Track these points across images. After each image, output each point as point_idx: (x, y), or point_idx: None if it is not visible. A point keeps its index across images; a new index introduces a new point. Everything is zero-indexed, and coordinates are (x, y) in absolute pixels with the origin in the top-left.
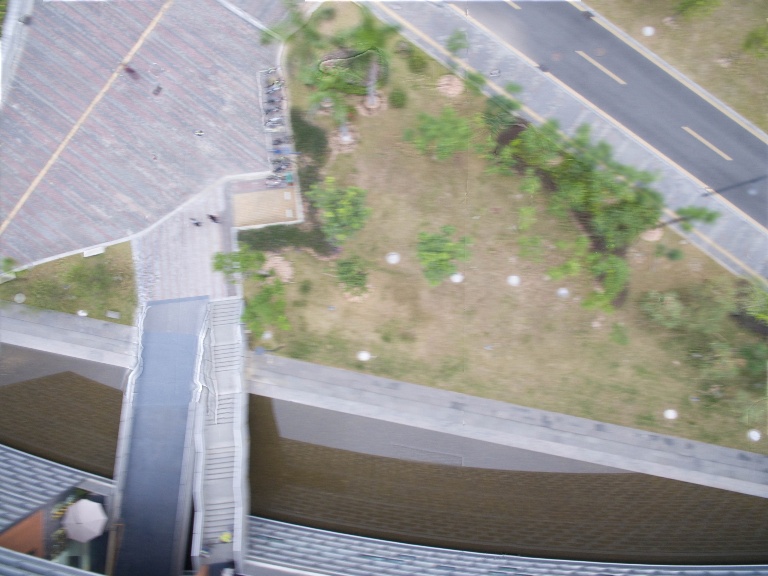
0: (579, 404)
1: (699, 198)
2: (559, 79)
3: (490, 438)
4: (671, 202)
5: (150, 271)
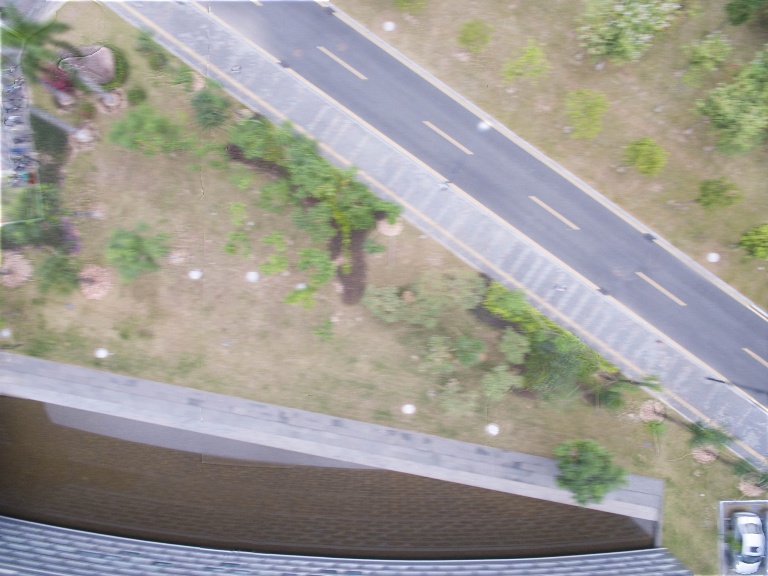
0: (316, 399)
1: (439, 192)
2: (300, 75)
3: (229, 434)
4: (411, 197)
5: None
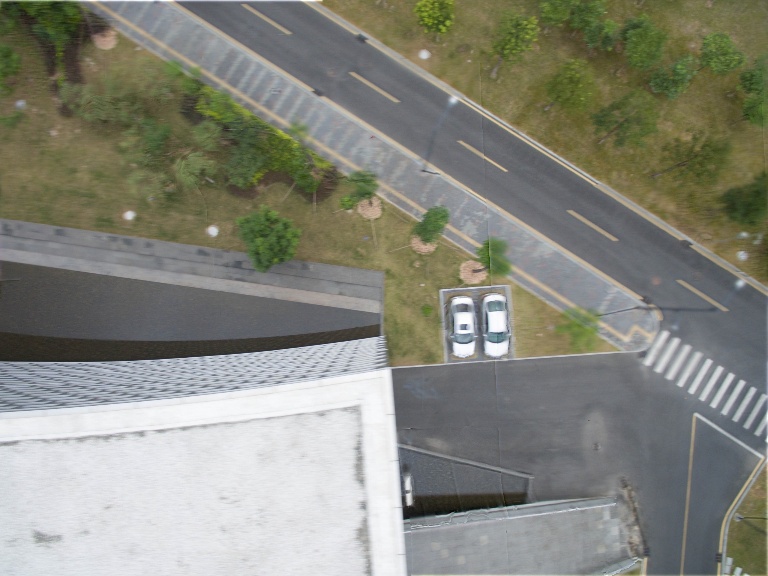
0: (39, 211)
1: (152, 5)
2: None
3: None
4: (126, 11)
5: None
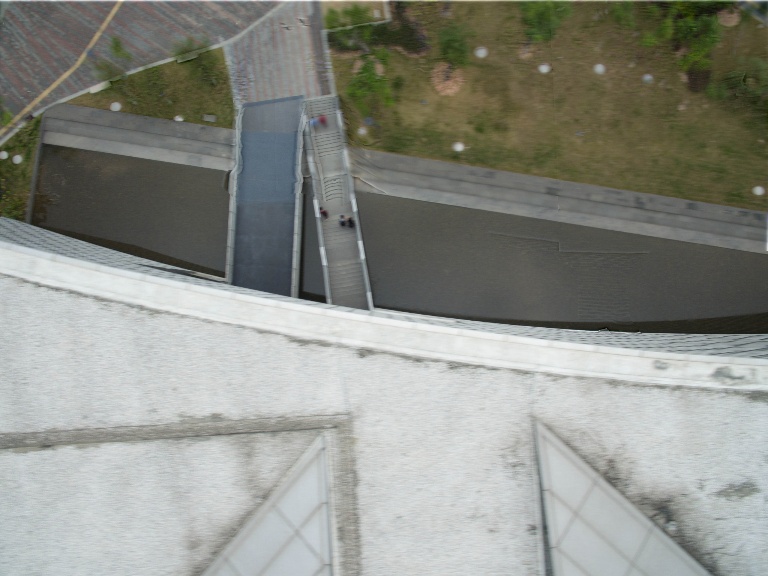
0: (670, 184)
1: None
2: None
3: (585, 222)
4: None
5: (243, 75)
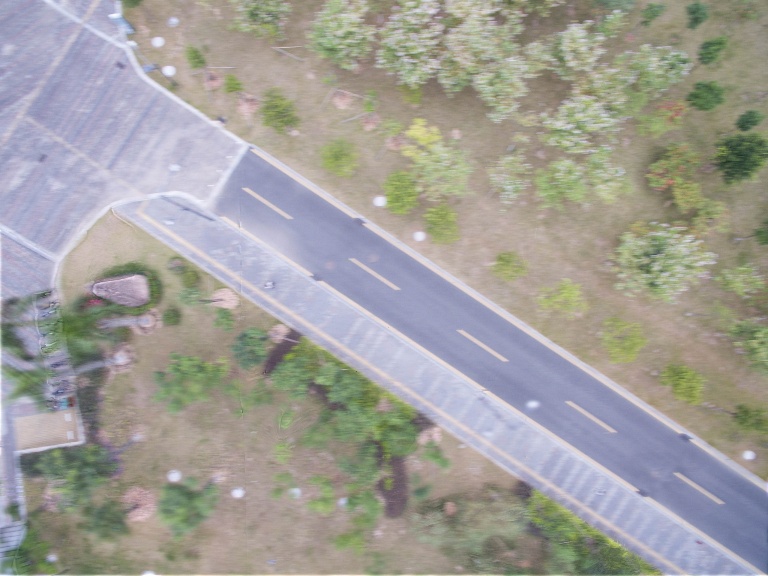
0: None
1: (476, 401)
2: (334, 287)
3: None
4: (449, 406)
5: None
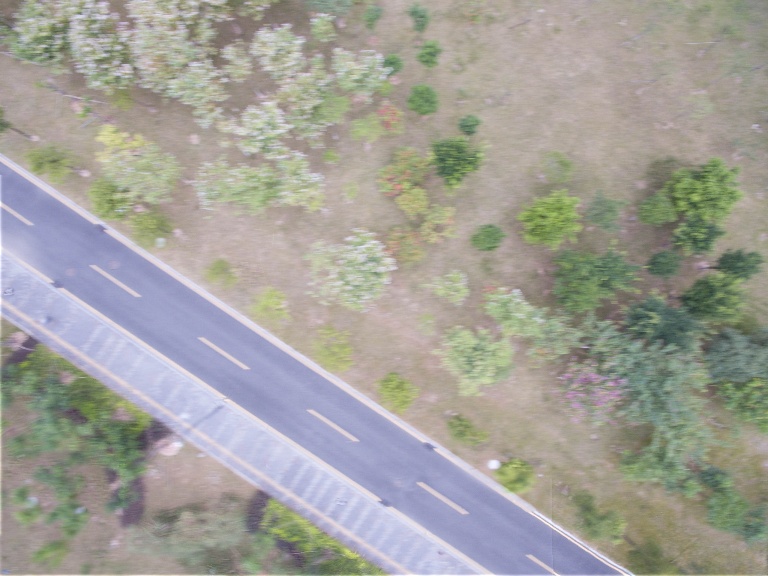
0: None
1: (216, 410)
2: (74, 294)
3: None
4: (188, 415)
5: None
